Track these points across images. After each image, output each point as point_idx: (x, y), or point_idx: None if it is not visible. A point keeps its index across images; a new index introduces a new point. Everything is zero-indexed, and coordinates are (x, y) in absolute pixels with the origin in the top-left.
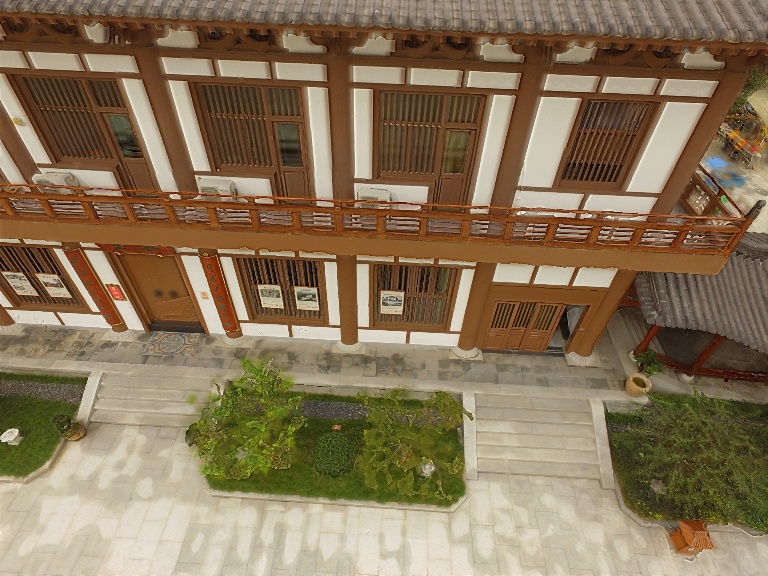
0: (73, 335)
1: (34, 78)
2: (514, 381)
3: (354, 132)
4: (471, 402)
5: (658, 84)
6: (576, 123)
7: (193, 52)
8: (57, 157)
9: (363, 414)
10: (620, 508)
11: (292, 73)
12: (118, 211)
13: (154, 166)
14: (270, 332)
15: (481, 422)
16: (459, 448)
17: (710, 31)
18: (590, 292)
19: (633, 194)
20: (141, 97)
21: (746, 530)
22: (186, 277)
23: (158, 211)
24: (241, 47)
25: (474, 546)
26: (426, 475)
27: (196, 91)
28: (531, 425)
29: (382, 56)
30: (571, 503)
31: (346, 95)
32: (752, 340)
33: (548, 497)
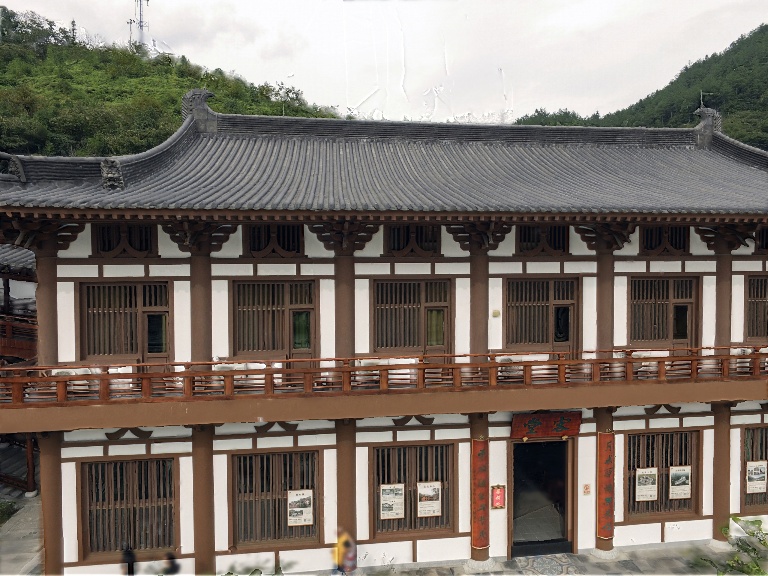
0: (430, 573)
1: (515, 282)
2: None
3: (731, 306)
4: None
5: None
6: None
7: (635, 258)
8: None
9: None
10: None
11: (694, 268)
12: (586, 372)
13: (583, 344)
14: (641, 538)
15: None
16: None
17: None
18: None
19: None
20: (592, 289)
21: None
22: (575, 465)
23: (618, 370)
24: (664, 254)
25: None
26: None
27: (630, 283)
28: None
29: (747, 255)
30: None
31: None
32: None
33: None
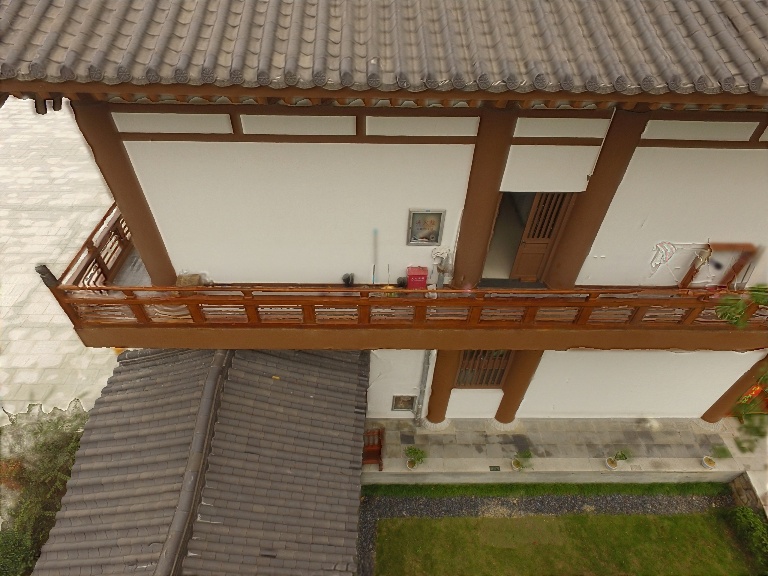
0: None
1: None
2: None
3: None
4: None
5: None
6: None
7: None
8: None
9: None
10: None
11: None
12: None
13: None
14: None
15: None
16: None
17: None
18: None
19: None
20: None
21: None
22: None
23: None
24: None
25: None
26: None
27: None
28: None
29: None
30: (95, 397)
31: None
32: (69, 482)
33: None
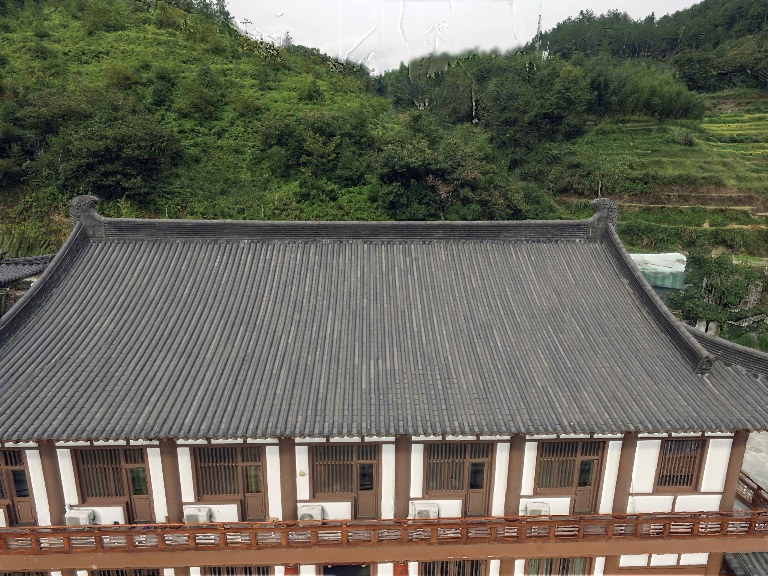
0: None
1: (322, 446)
2: None
3: (523, 466)
4: None
5: None
6: (660, 453)
7: None
8: (314, 494)
9: None
10: None
11: (489, 436)
12: (366, 536)
13: (382, 496)
14: None
15: None
16: None
17: (737, 425)
18: (694, 569)
19: (705, 494)
20: (390, 454)
21: None
22: None
23: (395, 533)
24: None
25: None
26: None
27: (427, 449)
28: None
29: None
30: None
31: (522, 446)
32: None
33: None
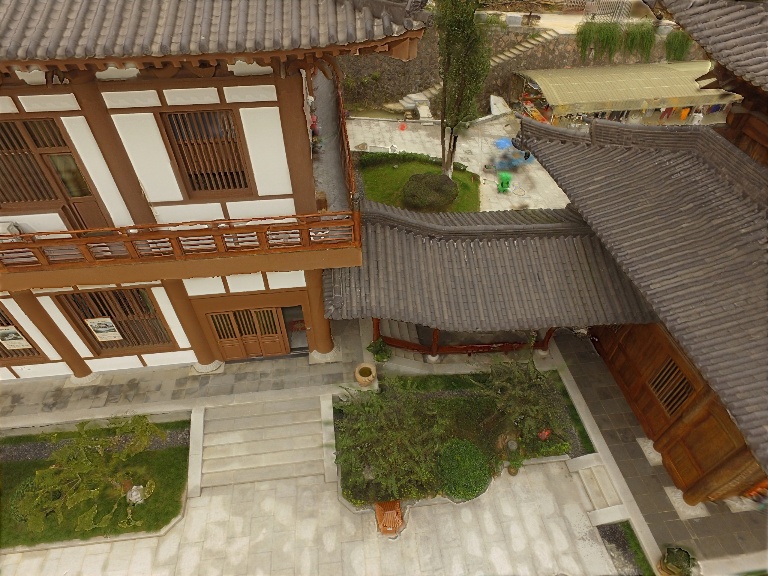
0: None
1: None
2: (249, 389)
3: None
4: (199, 418)
5: (218, 92)
6: (164, 137)
7: None
8: None
9: (93, 447)
10: (338, 499)
11: None
12: None
13: None
14: None
15: (210, 436)
16: (184, 467)
17: (130, 47)
18: (292, 293)
19: (267, 197)
20: None
21: (451, 499)
22: None
23: None
24: None
25: (177, 566)
26: (137, 502)
27: None
28: (261, 431)
29: None
30: (290, 503)
31: None
32: (429, 320)
33: (269, 501)
